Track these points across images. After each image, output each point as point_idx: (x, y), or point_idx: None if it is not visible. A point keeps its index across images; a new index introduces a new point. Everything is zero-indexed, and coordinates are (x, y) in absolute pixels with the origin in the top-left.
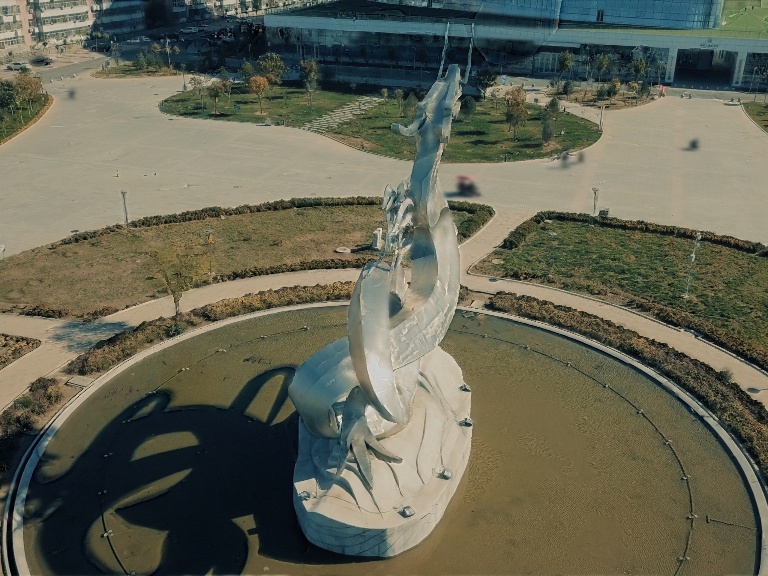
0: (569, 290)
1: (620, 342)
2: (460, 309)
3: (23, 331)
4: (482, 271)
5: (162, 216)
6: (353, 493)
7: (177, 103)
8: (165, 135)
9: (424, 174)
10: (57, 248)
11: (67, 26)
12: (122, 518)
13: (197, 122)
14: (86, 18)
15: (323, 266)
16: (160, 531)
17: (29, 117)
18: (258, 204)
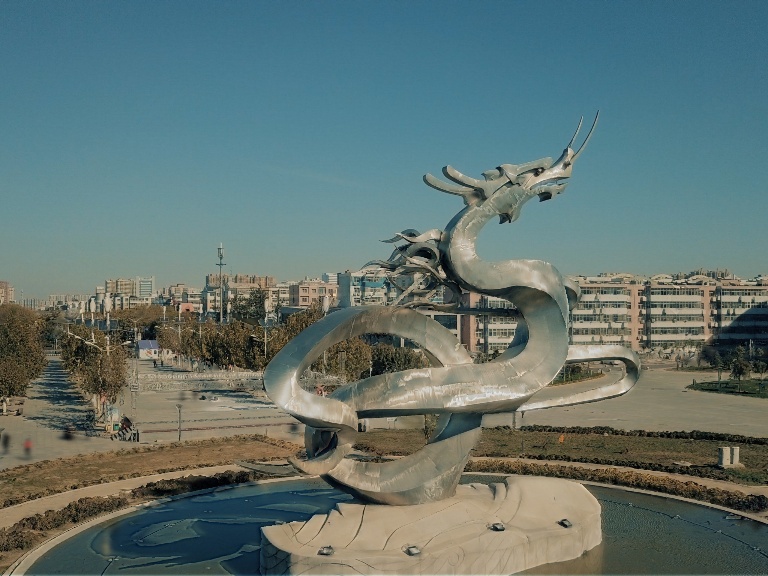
0: None
1: None
2: (728, 511)
3: None
4: None
5: (552, 427)
6: (304, 525)
7: (710, 384)
8: (660, 398)
9: (455, 224)
10: None
11: (677, 337)
12: (192, 523)
13: (708, 394)
14: (700, 332)
15: (632, 465)
16: None
17: (563, 381)
18: (654, 431)
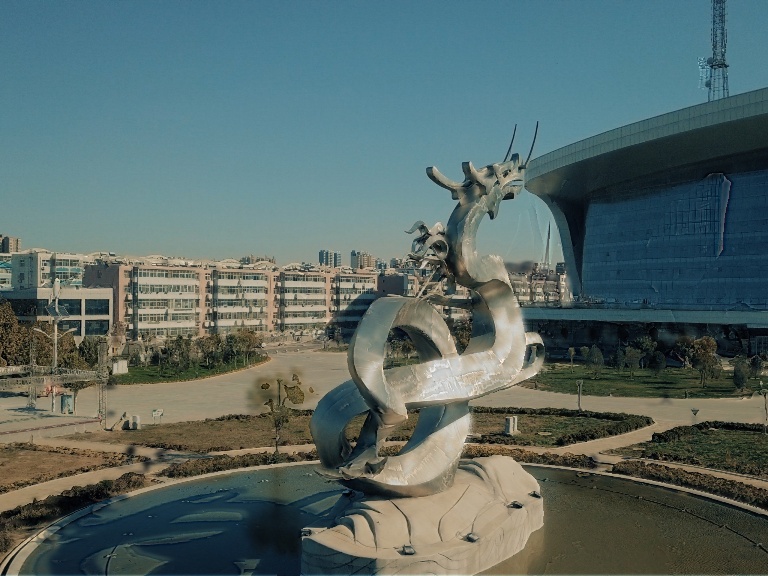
0: (714, 469)
1: (756, 498)
2: (575, 470)
3: (141, 454)
4: (617, 453)
5: None
6: (354, 529)
7: None
8: None
9: (460, 219)
10: (209, 422)
11: (306, 321)
12: (133, 550)
13: None
14: (323, 316)
15: None
16: (161, 561)
17: (243, 366)
18: None
